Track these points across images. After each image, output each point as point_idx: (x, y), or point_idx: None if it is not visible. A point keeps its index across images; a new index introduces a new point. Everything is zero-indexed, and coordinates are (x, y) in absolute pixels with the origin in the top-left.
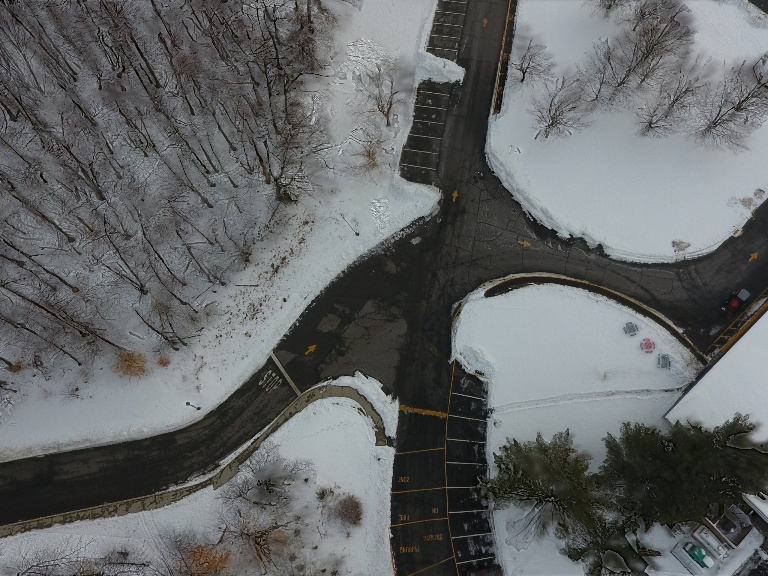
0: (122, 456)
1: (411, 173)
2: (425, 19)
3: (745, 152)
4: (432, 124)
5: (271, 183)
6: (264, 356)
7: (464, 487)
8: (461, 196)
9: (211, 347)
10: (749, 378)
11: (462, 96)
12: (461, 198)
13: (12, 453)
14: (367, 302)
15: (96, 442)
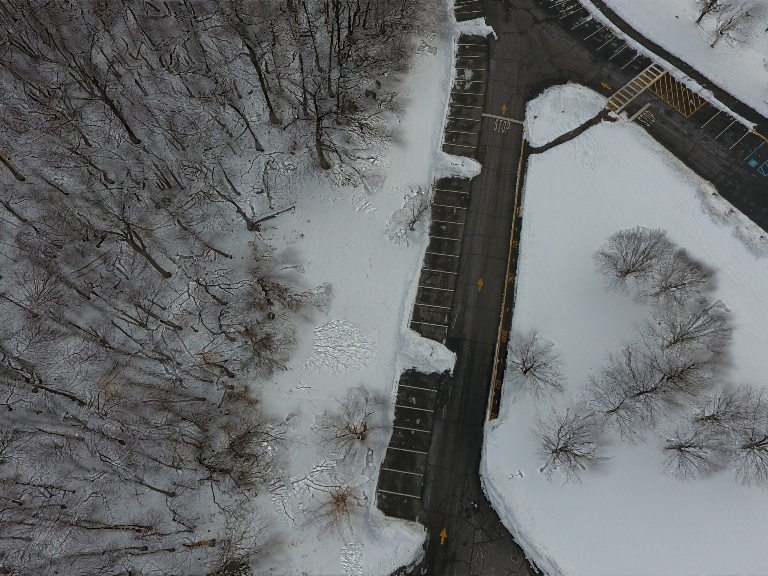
0: None
1: (390, 503)
2: (409, 283)
3: None
4: (416, 432)
5: (216, 545)
6: None
7: None
8: (451, 537)
9: None
10: None
11: (452, 392)
12: (451, 540)
13: None
14: None
15: None
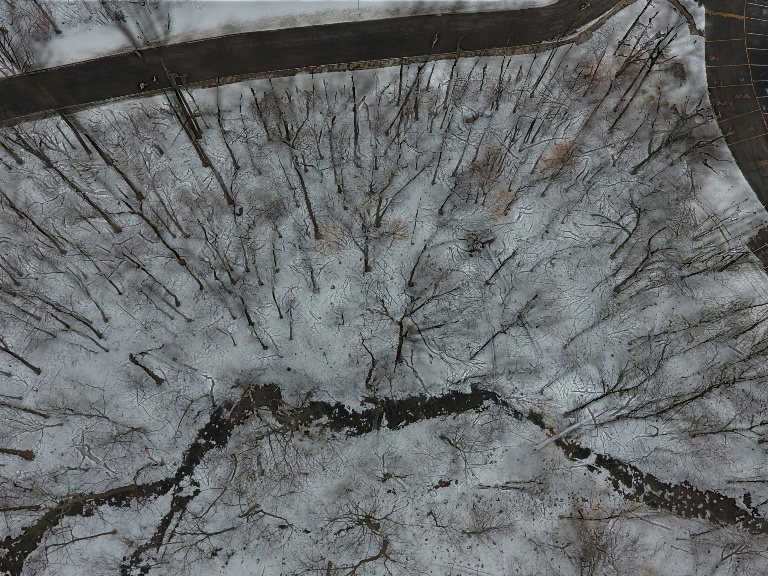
0: (501, 19)
1: None
2: None
3: None
4: None
5: None
6: None
7: (763, 65)
8: None
9: None
10: None
11: None
12: None
13: (418, 10)
14: None
15: (481, 8)
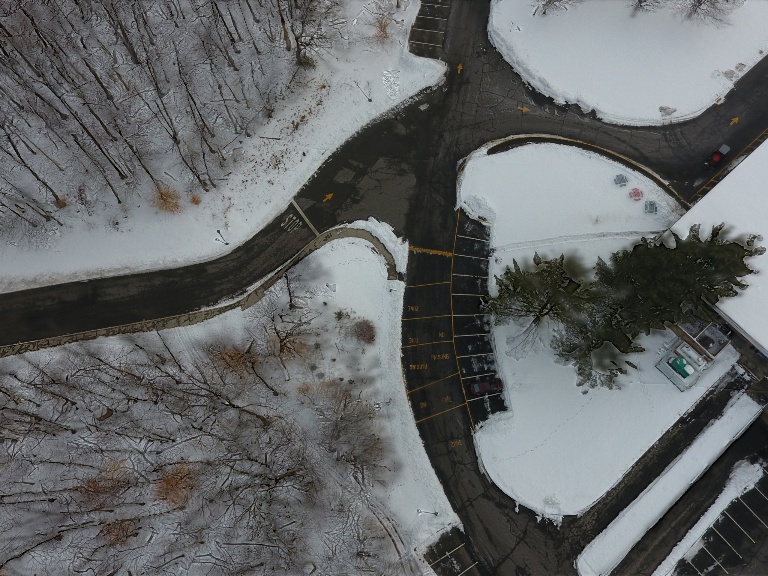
0: (158, 282)
1: (419, 49)
2: None
3: (727, 27)
4: (438, 7)
5: (291, 50)
6: (286, 202)
7: (468, 315)
8: (465, 69)
9: (238, 190)
10: (728, 214)
11: None
12: (465, 70)
13: (59, 277)
14: (379, 159)
15: (135, 269)
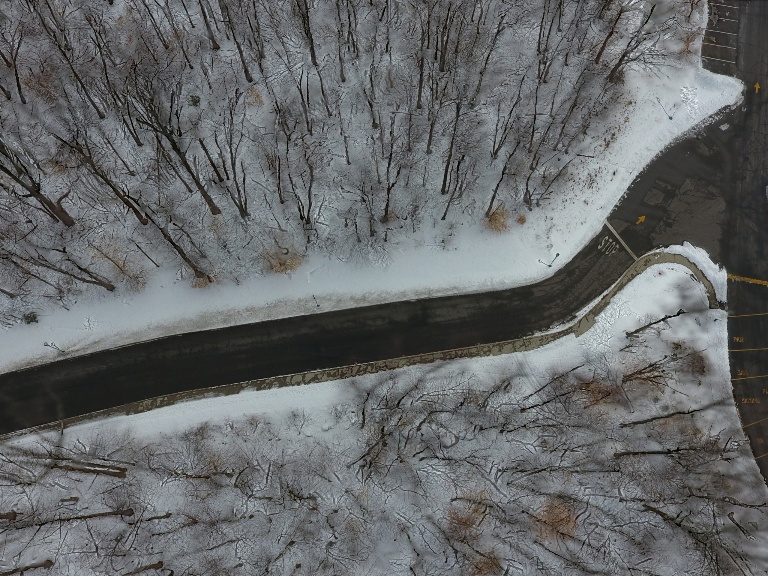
0: (487, 304)
1: (712, 65)
2: None
3: None
4: (727, 21)
5: (600, 63)
6: (600, 223)
7: None
8: (763, 88)
9: (559, 210)
10: None
11: None
12: (763, 90)
13: (388, 296)
14: (686, 180)
15: (463, 290)
